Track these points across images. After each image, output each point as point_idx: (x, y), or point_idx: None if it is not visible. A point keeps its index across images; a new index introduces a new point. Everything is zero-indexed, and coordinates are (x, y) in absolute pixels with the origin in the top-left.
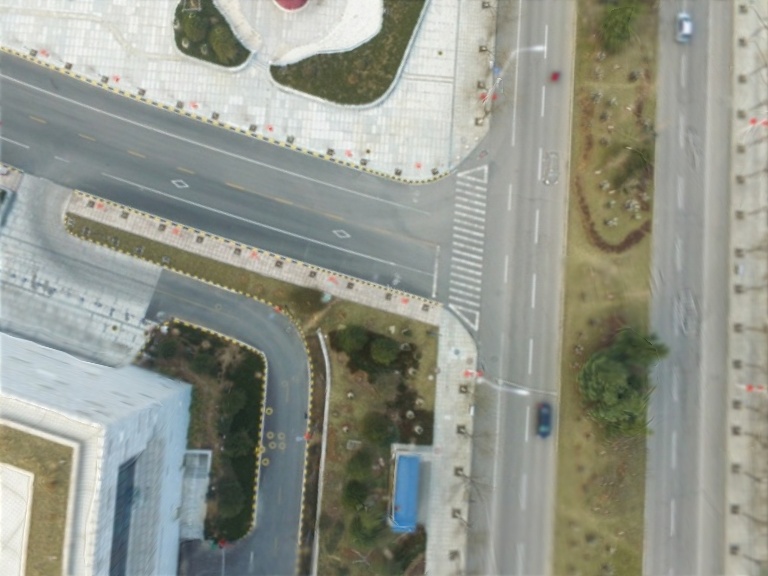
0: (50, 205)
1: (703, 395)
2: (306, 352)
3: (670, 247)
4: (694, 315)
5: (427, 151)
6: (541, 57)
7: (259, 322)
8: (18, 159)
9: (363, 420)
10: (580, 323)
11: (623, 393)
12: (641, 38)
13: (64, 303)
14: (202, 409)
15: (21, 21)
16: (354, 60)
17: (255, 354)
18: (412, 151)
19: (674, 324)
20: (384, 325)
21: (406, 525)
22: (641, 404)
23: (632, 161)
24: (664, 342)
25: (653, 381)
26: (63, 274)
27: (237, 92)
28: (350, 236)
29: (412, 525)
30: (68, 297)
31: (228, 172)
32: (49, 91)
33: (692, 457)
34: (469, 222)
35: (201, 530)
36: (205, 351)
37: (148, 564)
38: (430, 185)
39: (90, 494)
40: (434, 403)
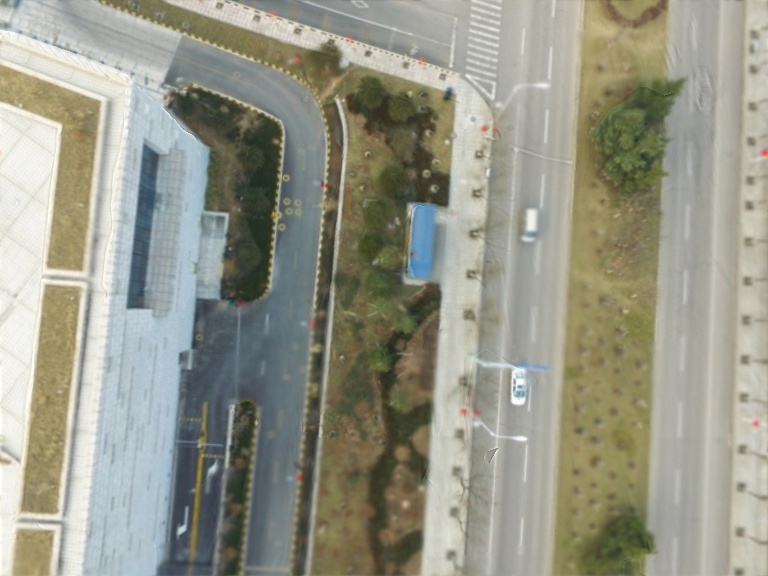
0: None
1: (717, 170)
2: (323, 121)
3: (686, 25)
4: (709, 92)
5: None
6: None
7: (277, 91)
8: None
9: (380, 178)
10: (596, 93)
11: (640, 135)
12: None
13: None
14: (220, 172)
15: None
16: None
17: (273, 121)
18: None
19: (689, 100)
20: (401, 90)
21: (421, 276)
22: (658, 144)
23: None
24: (679, 115)
25: (669, 126)
26: (84, 37)
27: None
28: (368, 6)
29: (427, 278)
30: None
31: None
32: None
33: (705, 229)
34: None
35: (217, 290)
36: (223, 115)
37: (168, 279)
38: None
39: (117, 148)
40: (450, 166)
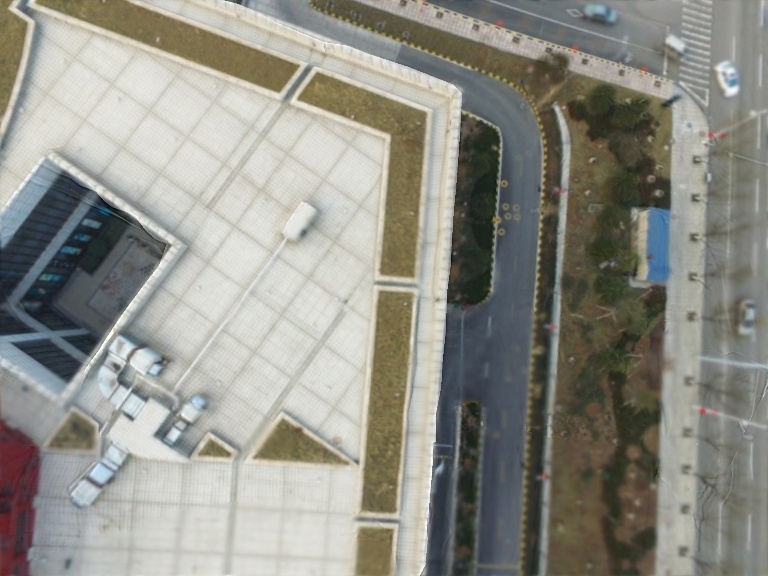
0: None
1: None
2: (539, 128)
3: None
4: None
5: None
6: None
7: (494, 98)
8: None
9: (605, 183)
10: None
11: None
12: None
13: None
14: None
15: None
16: None
17: (491, 128)
18: None
19: None
20: (621, 97)
21: (652, 279)
22: None
23: None
24: None
25: None
26: None
27: None
28: (583, 15)
29: (657, 281)
30: None
31: None
32: None
33: None
34: (697, 4)
35: None
36: None
37: None
38: None
39: (441, 158)
40: (670, 172)
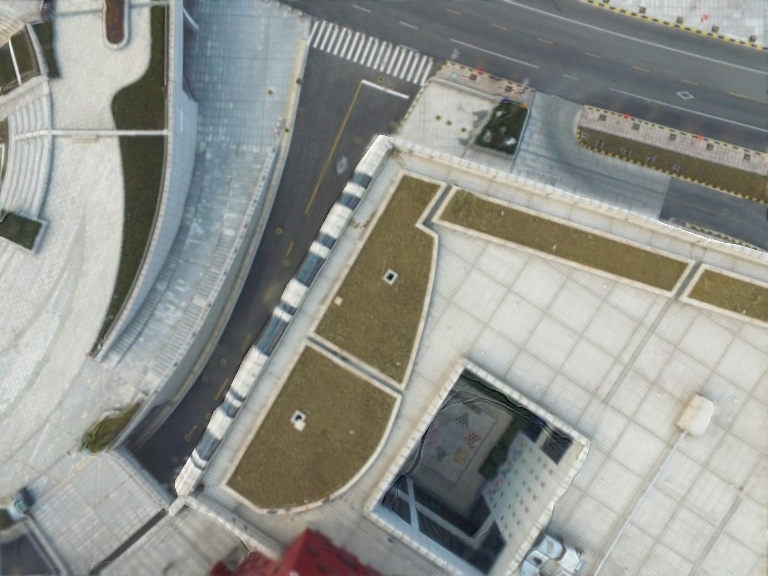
0: (562, 120)
1: None
2: None
3: None
4: None
5: None
6: None
7: (766, 225)
8: (530, 79)
9: None
10: None
11: None
12: None
13: None
14: None
15: None
16: None
17: None
18: None
19: None
20: None
21: None
22: None
23: None
24: None
25: None
26: (579, 185)
27: (736, 5)
28: None
29: None
30: None
31: (731, 82)
32: (553, 14)
33: None
34: None
35: None
36: None
37: None
38: None
39: None
40: None
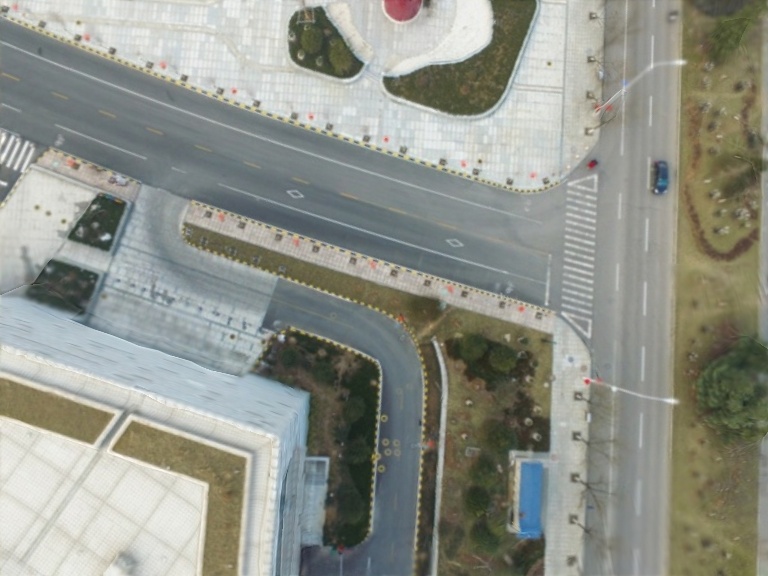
0: (168, 215)
1: None
2: (420, 360)
3: None
4: None
5: (538, 161)
6: (648, 67)
7: (373, 330)
8: (136, 170)
9: (482, 427)
10: (692, 331)
11: (749, 401)
12: (747, 48)
13: (183, 312)
14: (319, 417)
15: (137, 34)
16: (465, 71)
17: (370, 362)
18: (523, 161)
19: None
20: (500, 333)
21: (528, 531)
22: (767, 411)
23: (744, 170)
24: None
25: None
26: (181, 284)
27: (350, 103)
28: (463, 245)
29: (533, 531)
30: (186, 306)
31: (342, 182)
32: (165, 103)
33: None
34: (580, 231)
35: (320, 536)
36: (322, 359)
37: None
38: (541, 194)
39: (262, 503)
40: (550, 410)
